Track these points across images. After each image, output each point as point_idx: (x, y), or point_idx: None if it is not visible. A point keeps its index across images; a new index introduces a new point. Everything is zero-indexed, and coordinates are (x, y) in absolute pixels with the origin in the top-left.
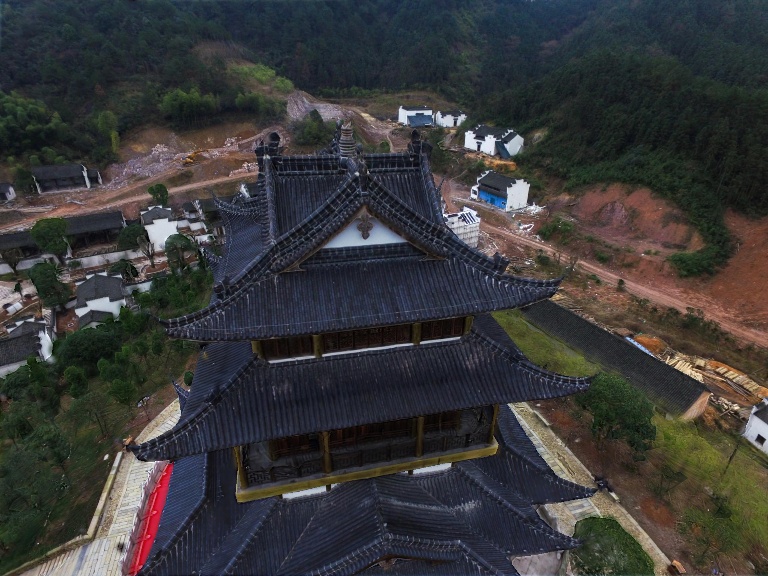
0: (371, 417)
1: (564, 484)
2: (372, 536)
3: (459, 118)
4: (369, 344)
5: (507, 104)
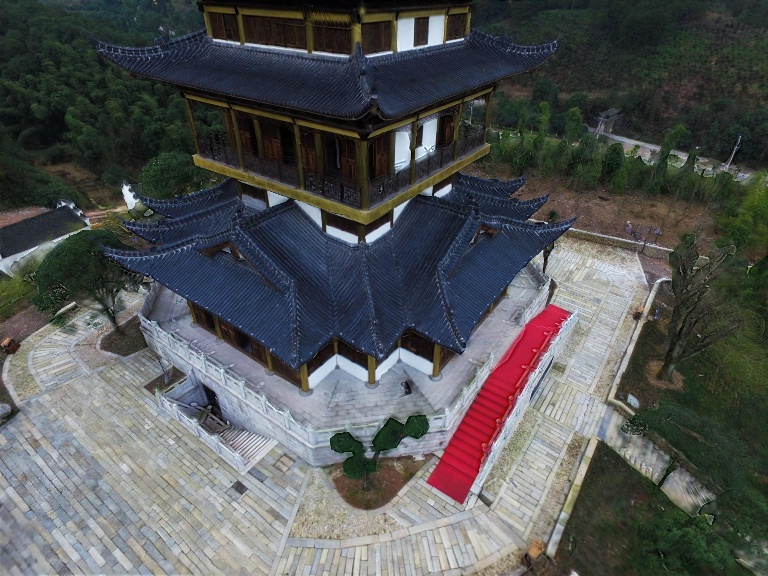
0: None
1: None
2: None
3: None
4: None
5: None
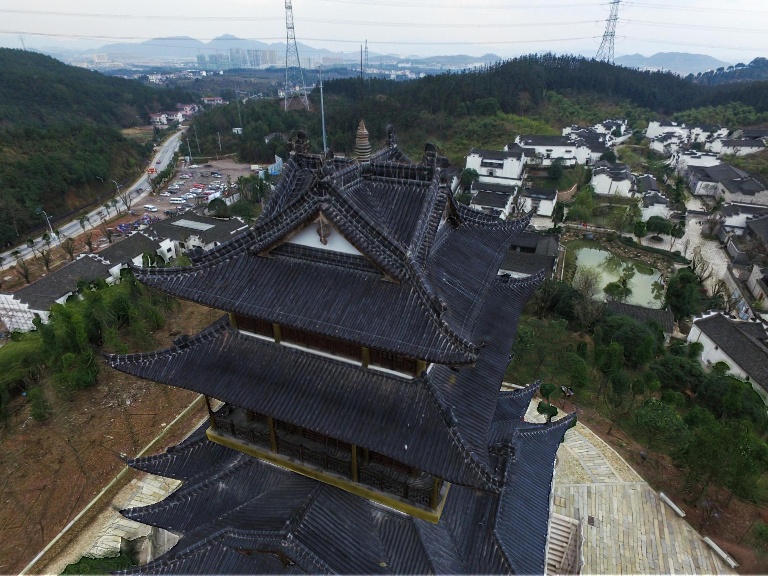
0: None
1: None
2: None
3: None
4: None
5: None
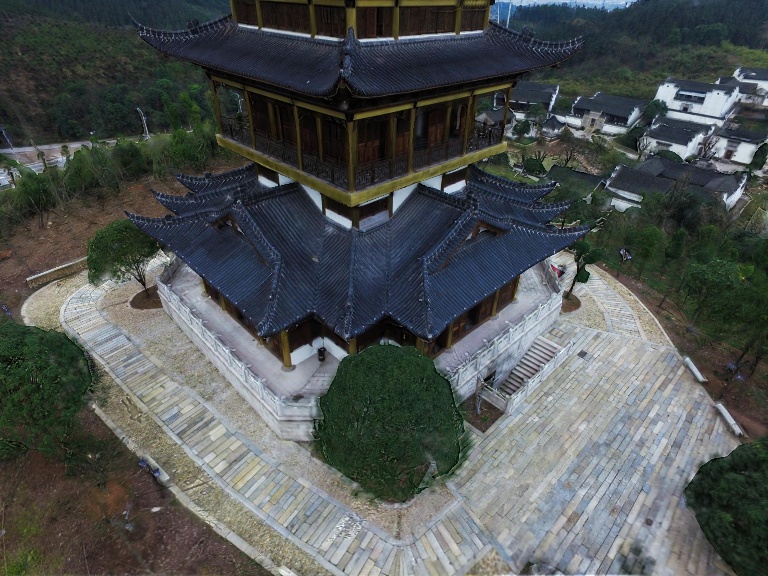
0: None
1: None
2: None
3: None
4: None
5: None
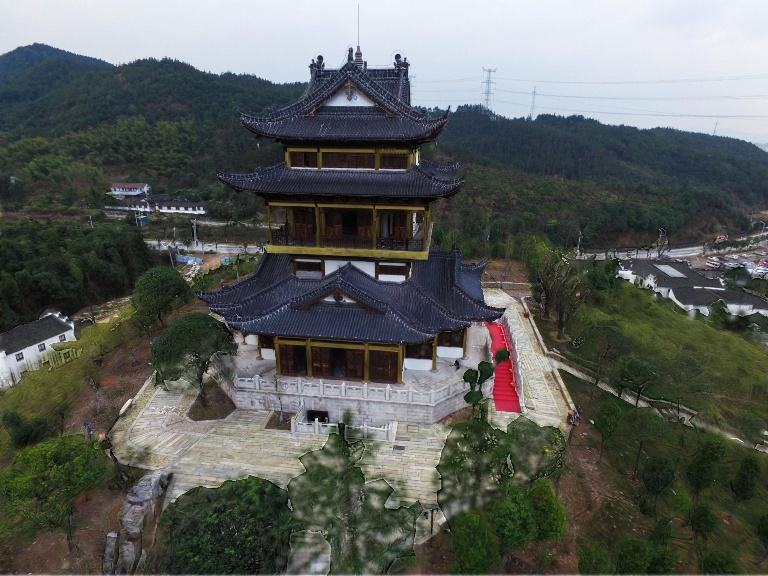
0: None
1: None
2: None
3: None
4: None
5: None
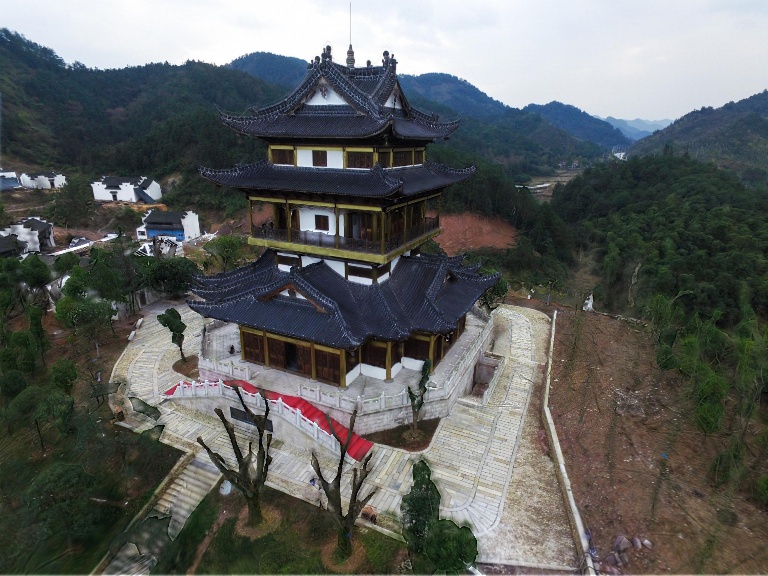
0: (432, 186)
1: (453, 259)
2: (434, 270)
3: (55, 179)
4: (402, 164)
5: (124, 156)
